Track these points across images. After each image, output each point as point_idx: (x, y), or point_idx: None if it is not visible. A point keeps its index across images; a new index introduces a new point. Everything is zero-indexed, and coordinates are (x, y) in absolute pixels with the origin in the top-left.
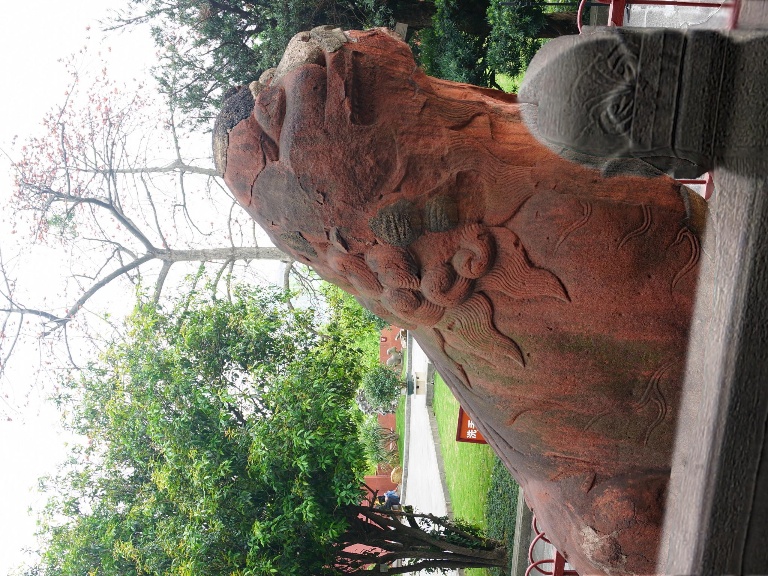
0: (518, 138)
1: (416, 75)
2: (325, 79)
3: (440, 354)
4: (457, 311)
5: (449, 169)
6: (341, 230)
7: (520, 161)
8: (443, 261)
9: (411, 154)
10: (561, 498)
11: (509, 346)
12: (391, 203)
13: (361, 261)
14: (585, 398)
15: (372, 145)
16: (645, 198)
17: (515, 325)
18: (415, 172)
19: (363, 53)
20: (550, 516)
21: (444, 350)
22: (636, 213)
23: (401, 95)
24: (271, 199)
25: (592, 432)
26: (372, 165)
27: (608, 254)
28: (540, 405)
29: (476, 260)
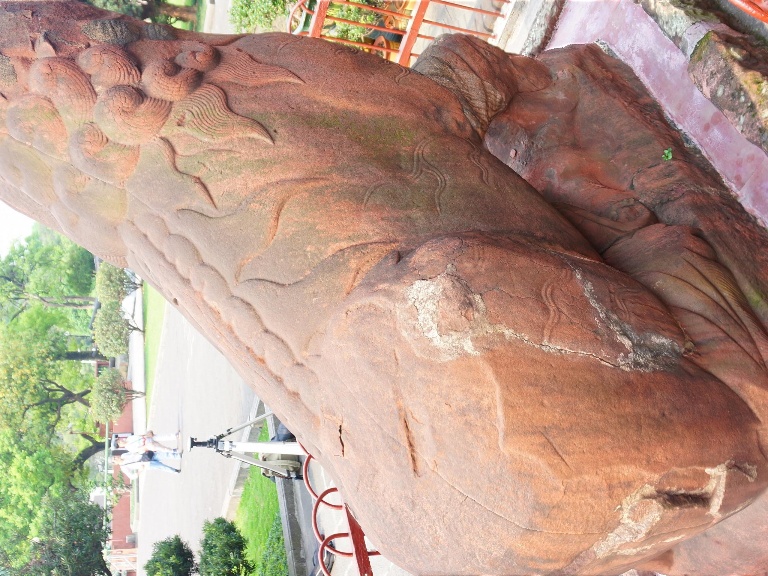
0: None
1: None
2: None
3: (171, 176)
4: (186, 103)
5: None
6: (49, 34)
7: None
8: (165, 58)
9: None
10: (367, 289)
11: (251, 123)
12: None
13: (71, 62)
14: (352, 168)
15: None
16: None
17: (253, 105)
18: None
19: None
20: (363, 342)
21: (175, 167)
22: None
23: None
24: None
25: (374, 204)
26: (86, 7)
27: (328, 55)
28: (303, 182)
29: (200, 52)
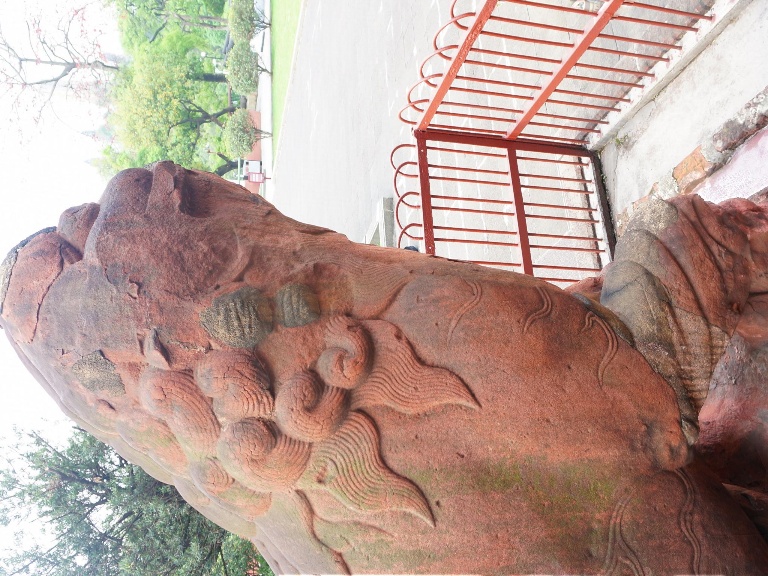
0: (379, 248)
1: (258, 196)
2: (150, 176)
3: (308, 542)
4: (329, 446)
5: (303, 262)
6: (161, 332)
7: (386, 260)
8: (304, 367)
9: (256, 244)
10: None
11: (409, 491)
12: (231, 291)
13: (188, 380)
14: (530, 569)
15: (206, 233)
16: (537, 283)
17: (413, 455)
18: (261, 262)
19: (197, 173)
20: None
21: (313, 532)
22: (532, 294)
23: (242, 204)
24: (64, 313)
25: None
26: (206, 251)
27: (514, 338)
28: None
29: (349, 357)
